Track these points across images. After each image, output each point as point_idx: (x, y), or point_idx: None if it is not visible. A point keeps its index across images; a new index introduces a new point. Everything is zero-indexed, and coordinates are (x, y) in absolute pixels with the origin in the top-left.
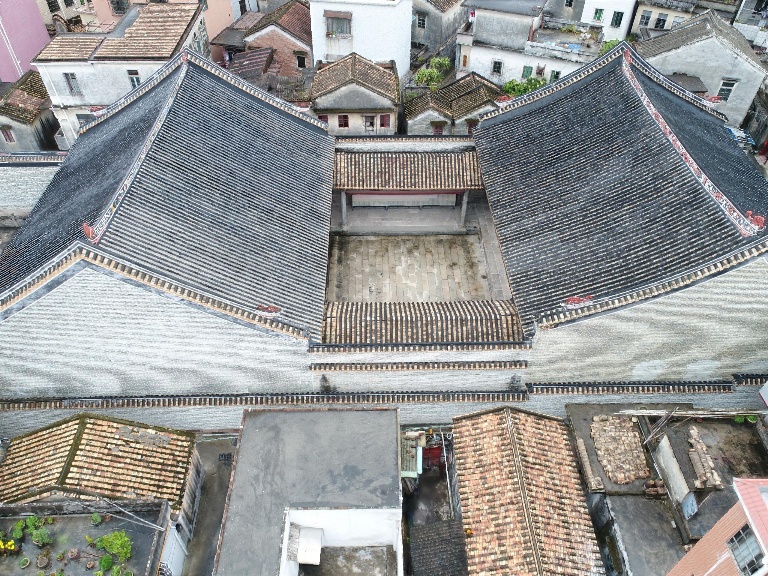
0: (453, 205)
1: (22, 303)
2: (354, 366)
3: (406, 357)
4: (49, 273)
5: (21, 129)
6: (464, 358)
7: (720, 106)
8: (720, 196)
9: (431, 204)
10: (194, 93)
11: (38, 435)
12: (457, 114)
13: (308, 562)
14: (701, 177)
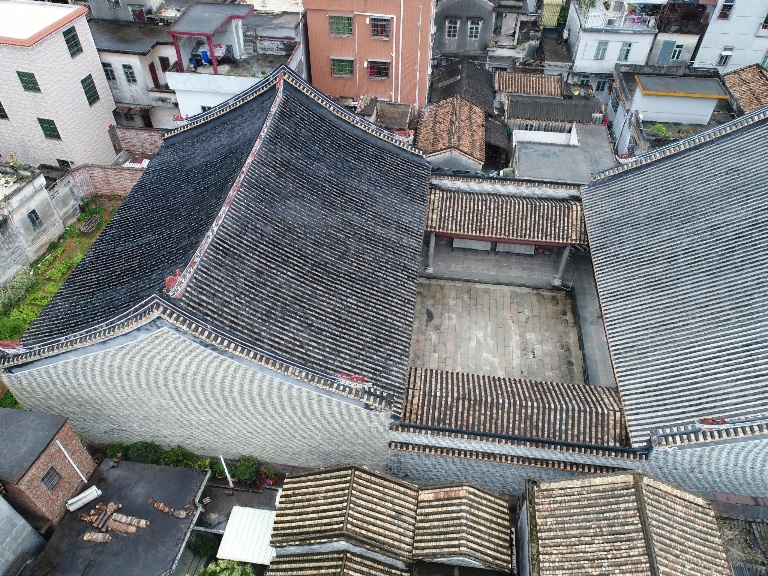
0: None
1: None
2: None
3: None
4: None
5: None
6: None
7: None
8: None
9: None
10: None
11: None
12: None
13: None
14: None
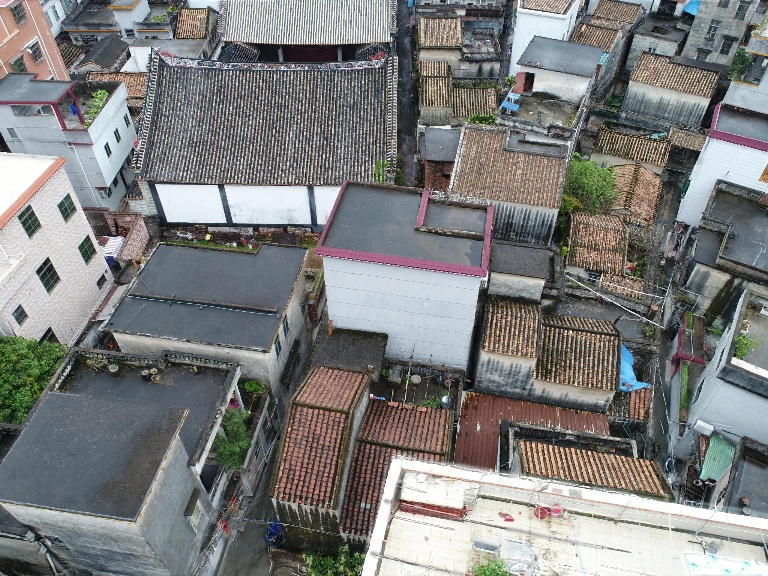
0: None
1: None
2: None
3: None
4: None
5: None
6: None
7: None
8: None
9: None
10: None
11: None
12: None
13: None
14: None
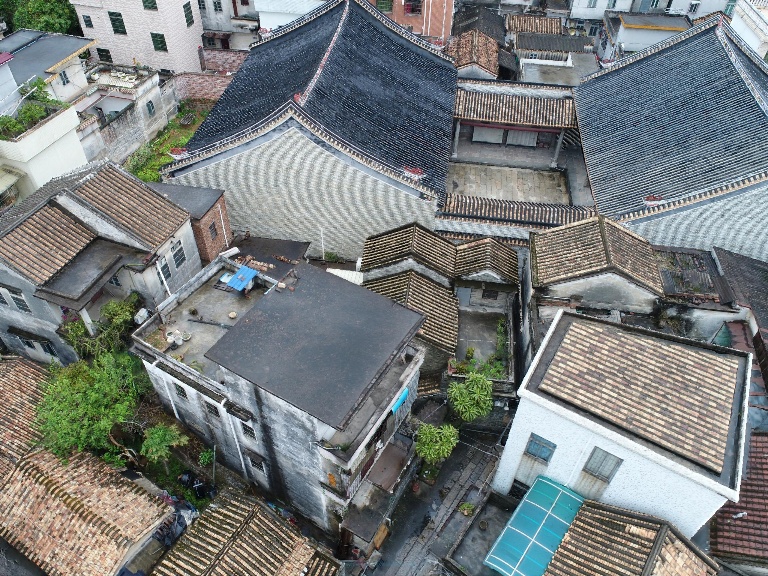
0: None
1: None
2: None
3: None
4: None
5: None
6: None
7: None
8: None
9: None
10: (767, 145)
11: None
12: None
13: None
14: None
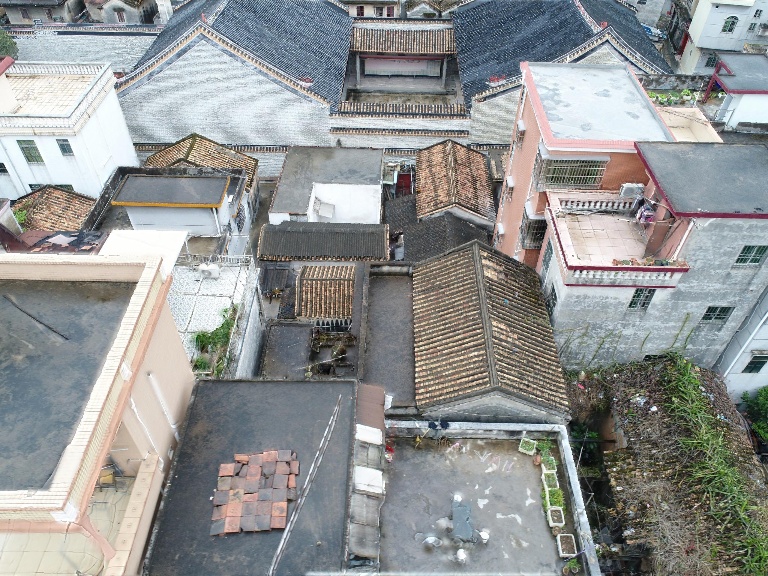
0: (438, 76)
1: (161, 67)
2: (358, 131)
3: (391, 124)
4: (180, 43)
5: (131, 12)
6: (428, 127)
7: (641, 9)
8: (591, 21)
9: (422, 74)
10: None
11: (166, 150)
12: (443, 8)
13: (325, 216)
14: (585, 15)
